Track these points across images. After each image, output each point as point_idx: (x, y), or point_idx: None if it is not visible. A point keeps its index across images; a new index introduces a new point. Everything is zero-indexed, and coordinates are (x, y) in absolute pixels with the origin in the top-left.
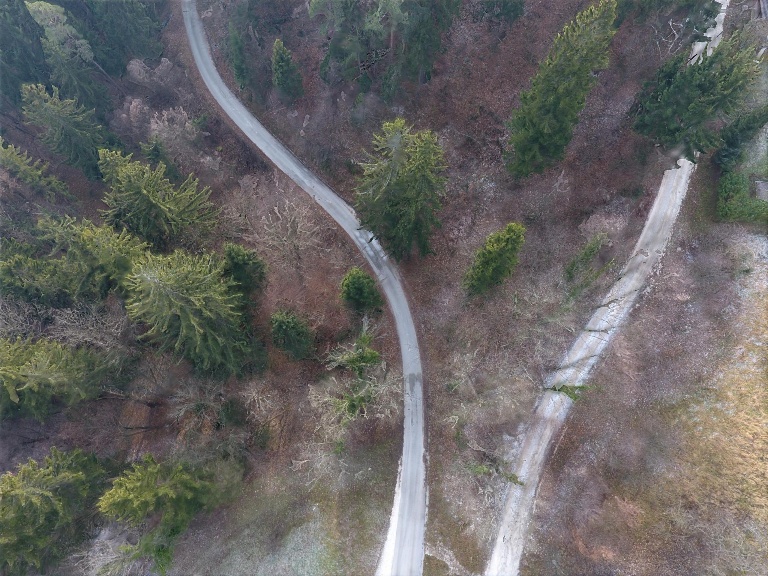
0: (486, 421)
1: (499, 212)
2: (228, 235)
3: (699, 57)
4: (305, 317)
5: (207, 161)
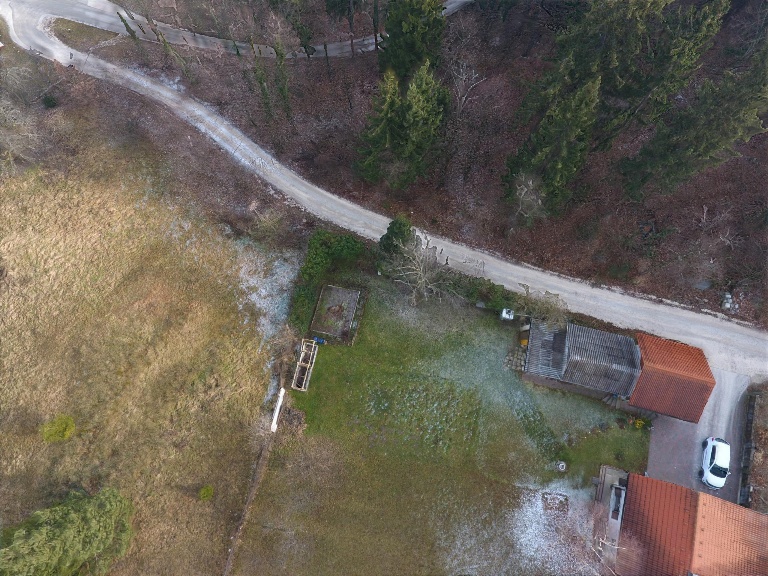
0: (197, 76)
1: None
2: None
3: (436, 95)
4: (318, 0)
5: None
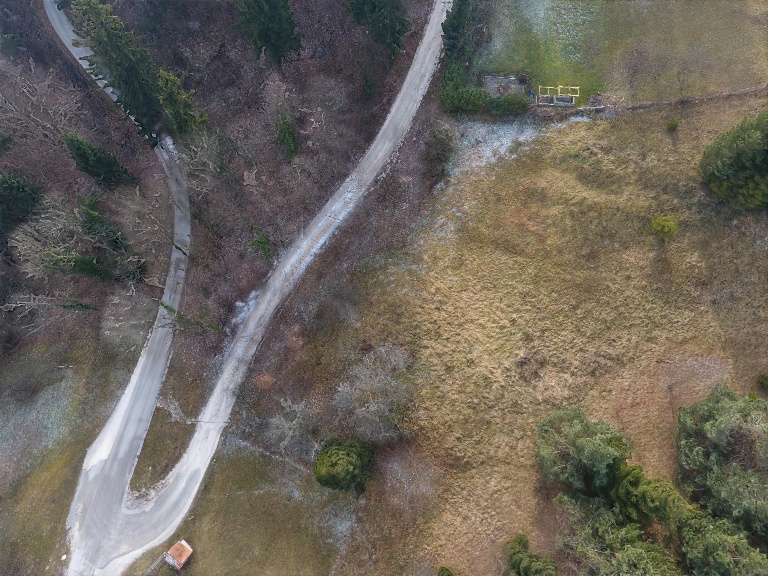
0: (228, 293)
1: (273, 114)
2: (1, 124)
3: None
4: None
5: (1, 64)
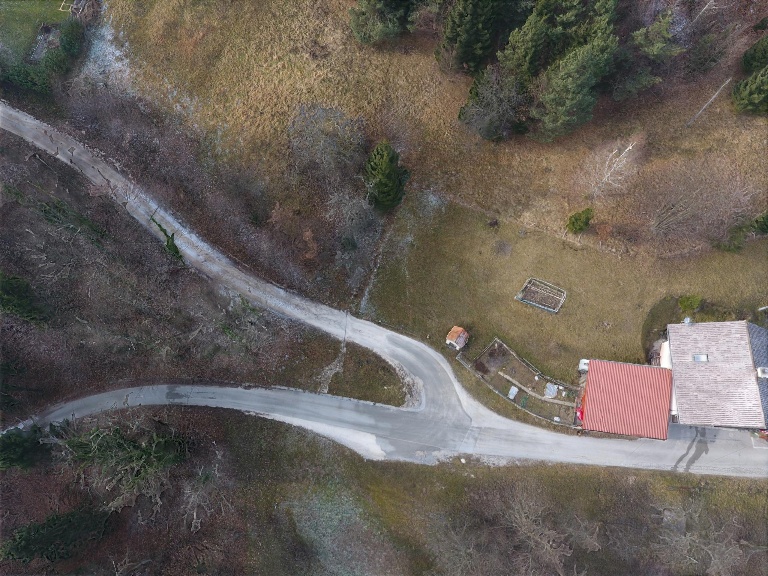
0: None
1: None
2: None
3: None
4: None
5: None
